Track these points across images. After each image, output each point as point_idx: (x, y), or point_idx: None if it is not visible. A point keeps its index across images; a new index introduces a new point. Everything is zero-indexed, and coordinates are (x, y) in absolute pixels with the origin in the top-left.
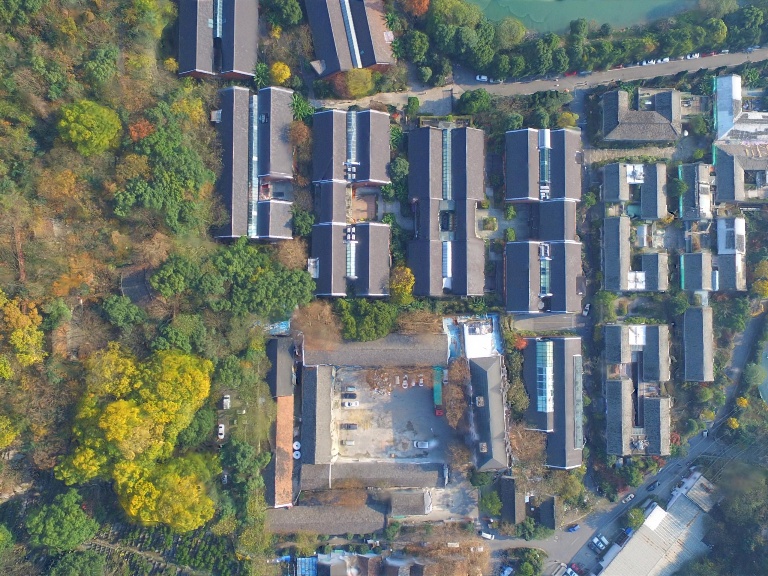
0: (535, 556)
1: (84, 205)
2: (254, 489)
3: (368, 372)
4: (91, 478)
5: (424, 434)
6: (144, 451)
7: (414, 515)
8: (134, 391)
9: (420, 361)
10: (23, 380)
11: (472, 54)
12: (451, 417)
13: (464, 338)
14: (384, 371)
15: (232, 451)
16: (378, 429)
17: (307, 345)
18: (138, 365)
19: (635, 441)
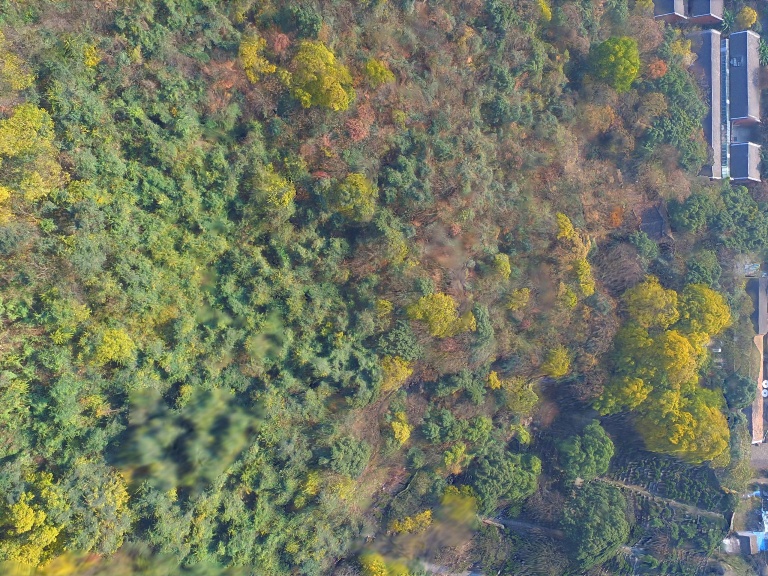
0: None
1: (629, 139)
2: (743, 424)
3: None
4: (635, 407)
5: None
6: (689, 381)
7: None
8: (679, 322)
9: None
10: (586, 310)
11: None
12: None
13: None
14: None
15: (737, 385)
16: None
17: None
18: (679, 297)
19: None
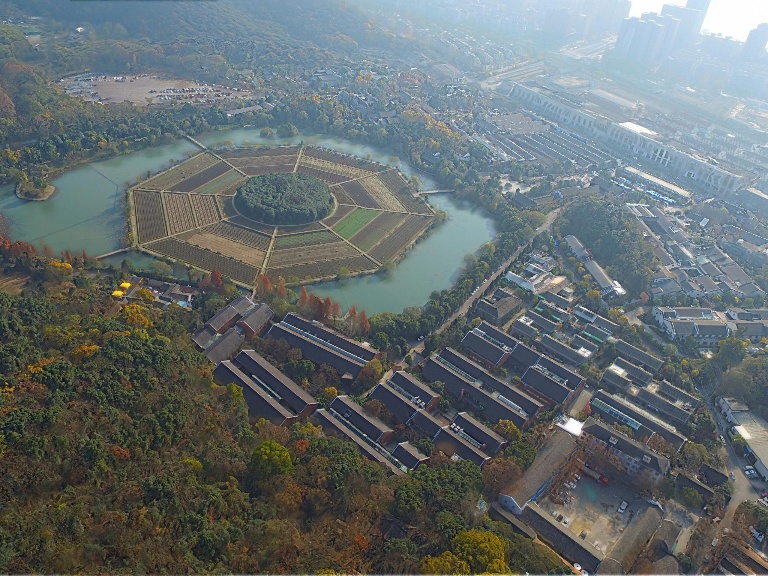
0: (746, 503)
1: (321, 491)
2: None
3: (549, 498)
4: None
5: (616, 502)
6: None
7: (678, 537)
8: (472, 568)
9: (565, 452)
10: None
11: (410, 326)
12: (615, 463)
13: (565, 430)
14: (555, 490)
15: None
16: (595, 523)
17: (509, 494)
18: (454, 553)
19: (684, 407)
